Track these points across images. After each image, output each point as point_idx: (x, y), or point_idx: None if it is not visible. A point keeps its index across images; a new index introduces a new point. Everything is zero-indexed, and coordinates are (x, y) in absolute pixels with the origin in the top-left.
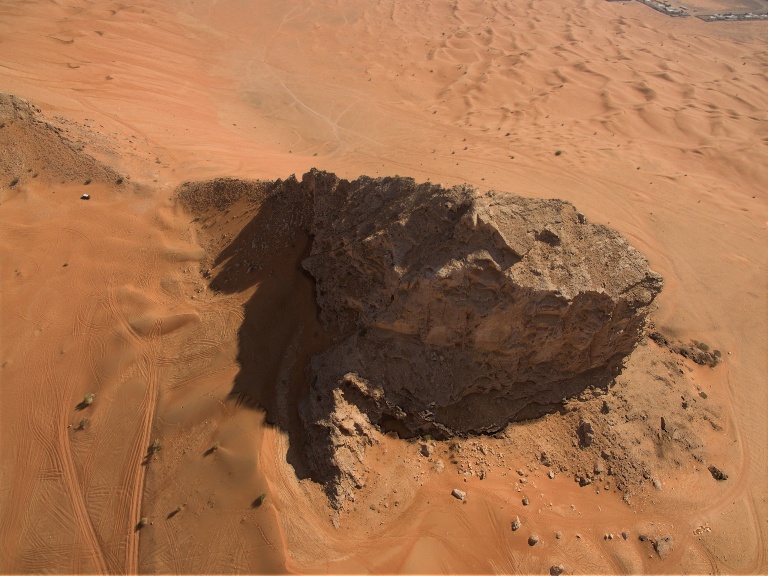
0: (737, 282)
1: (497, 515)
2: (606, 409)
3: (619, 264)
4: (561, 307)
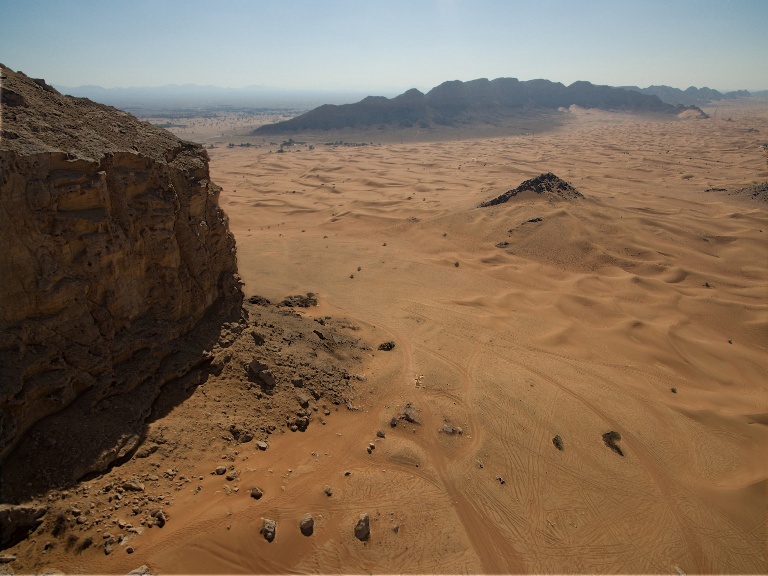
0: (282, 263)
1: (230, 545)
2: (259, 339)
3: (138, 132)
4: (91, 182)
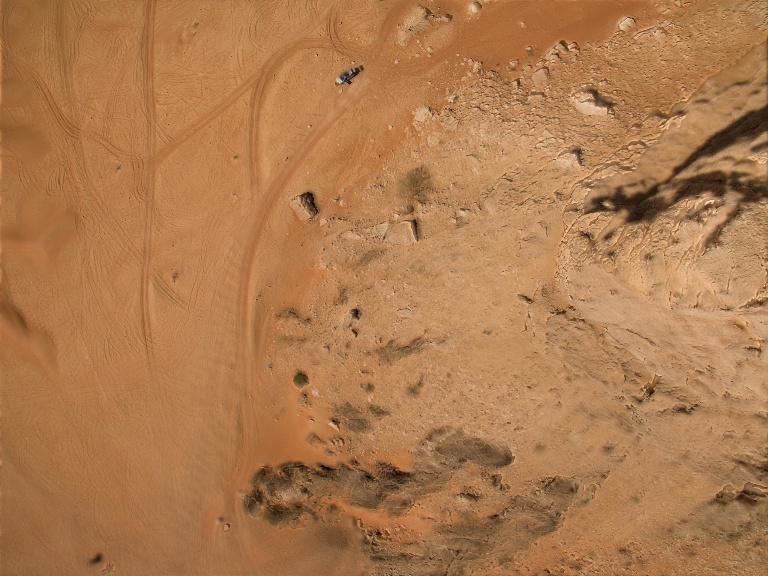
0: None
1: None
2: None
3: None
4: None
